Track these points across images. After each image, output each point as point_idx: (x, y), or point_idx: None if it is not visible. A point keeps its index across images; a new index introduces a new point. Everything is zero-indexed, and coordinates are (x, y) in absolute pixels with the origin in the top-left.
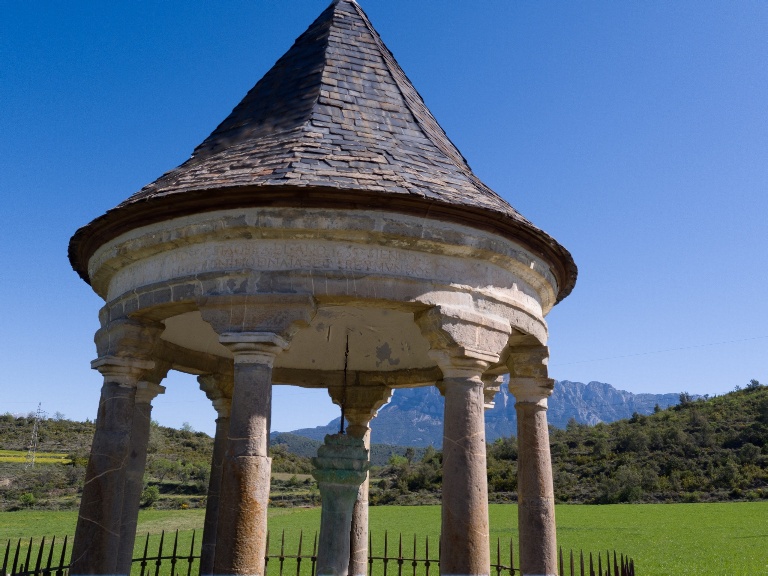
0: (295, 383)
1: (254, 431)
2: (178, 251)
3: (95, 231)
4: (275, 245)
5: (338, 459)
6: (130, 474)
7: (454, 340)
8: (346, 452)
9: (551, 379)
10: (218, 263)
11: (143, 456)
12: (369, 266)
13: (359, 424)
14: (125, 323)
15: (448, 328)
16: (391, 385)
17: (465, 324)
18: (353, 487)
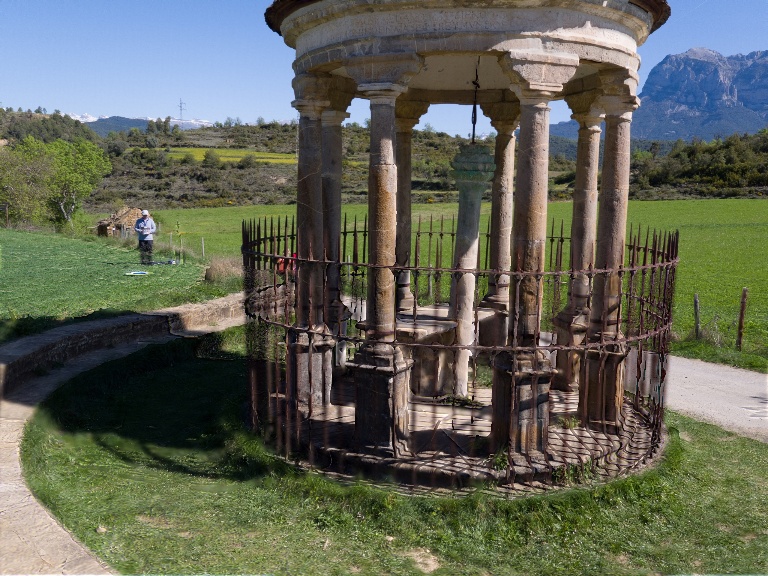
0: (453, 102)
1: (384, 149)
2: (329, 24)
3: (278, 9)
4: (390, 16)
5: (467, 163)
6: (333, 175)
7: (523, 77)
8: (473, 158)
9: (633, 96)
10: (354, 32)
11: (340, 163)
12: (456, 26)
13: (505, 133)
14: (305, 77)
15: (518, 68)
16: None
17: (533, 64)
18: (479, 183)
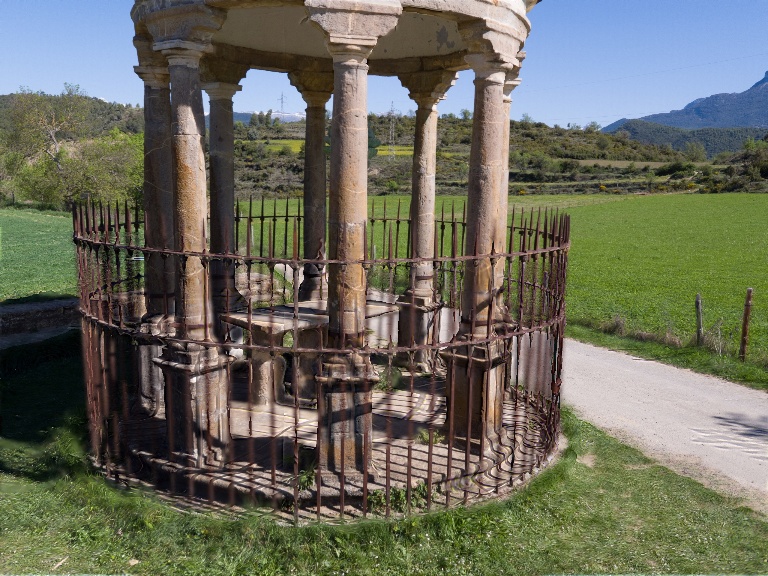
0: (370, 73)
1: (181, 117)
2: None
3: None
4: None
5: None
6: (220, 153)
7: (324, 29)
8: None
9: (497, 53)
10: None
11: (229, 140)
12: None
13: (424, 107)
14: (135, 40)
15: (317, 18)
16: (448, 68)
17: (335, 12)
18: None
